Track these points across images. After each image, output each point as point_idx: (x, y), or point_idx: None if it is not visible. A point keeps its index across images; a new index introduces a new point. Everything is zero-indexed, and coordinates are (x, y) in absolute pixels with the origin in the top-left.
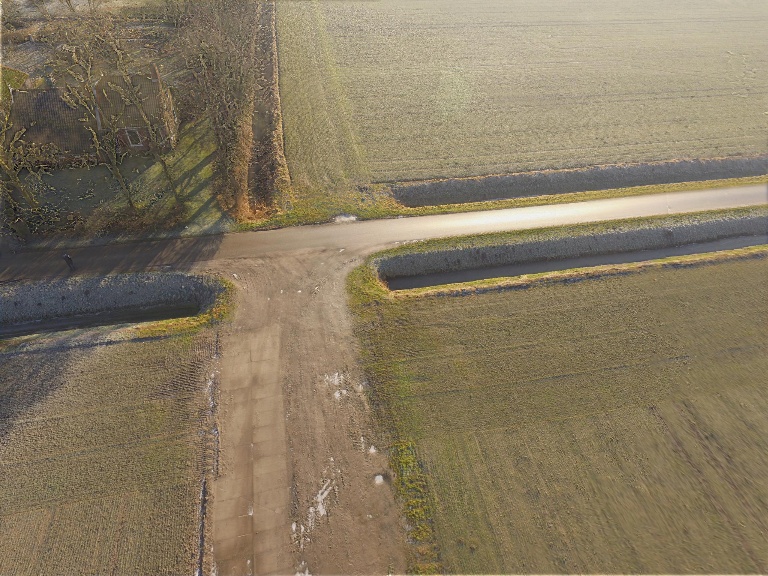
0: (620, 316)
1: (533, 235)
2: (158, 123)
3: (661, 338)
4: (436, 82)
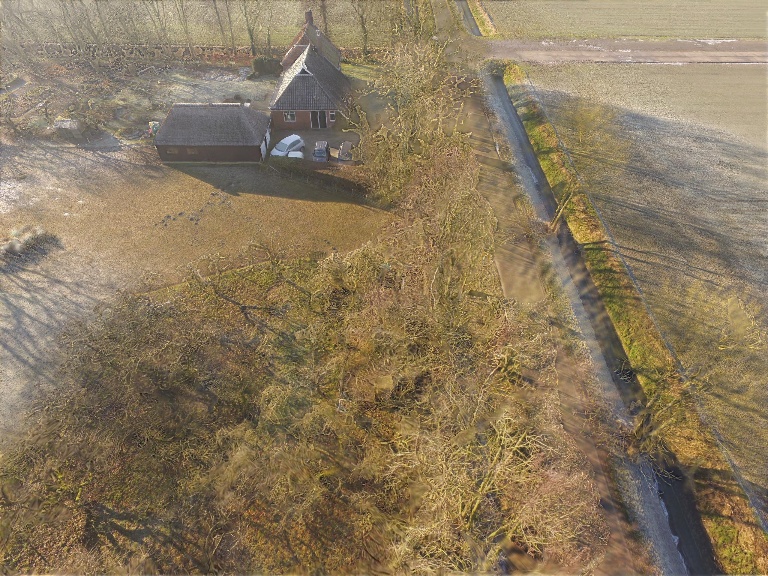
0: (507, 4)
1: (454, 8)
2: (339, 52)
3: (518, 1)
4: (276, 4)
